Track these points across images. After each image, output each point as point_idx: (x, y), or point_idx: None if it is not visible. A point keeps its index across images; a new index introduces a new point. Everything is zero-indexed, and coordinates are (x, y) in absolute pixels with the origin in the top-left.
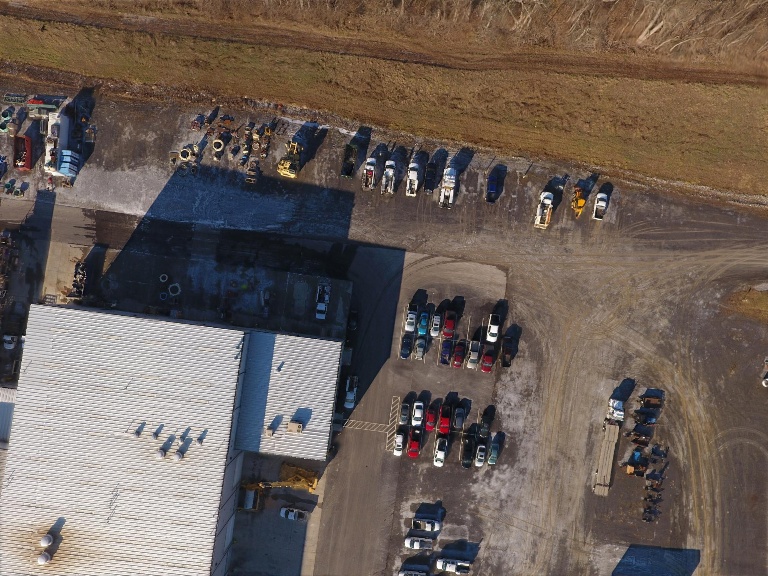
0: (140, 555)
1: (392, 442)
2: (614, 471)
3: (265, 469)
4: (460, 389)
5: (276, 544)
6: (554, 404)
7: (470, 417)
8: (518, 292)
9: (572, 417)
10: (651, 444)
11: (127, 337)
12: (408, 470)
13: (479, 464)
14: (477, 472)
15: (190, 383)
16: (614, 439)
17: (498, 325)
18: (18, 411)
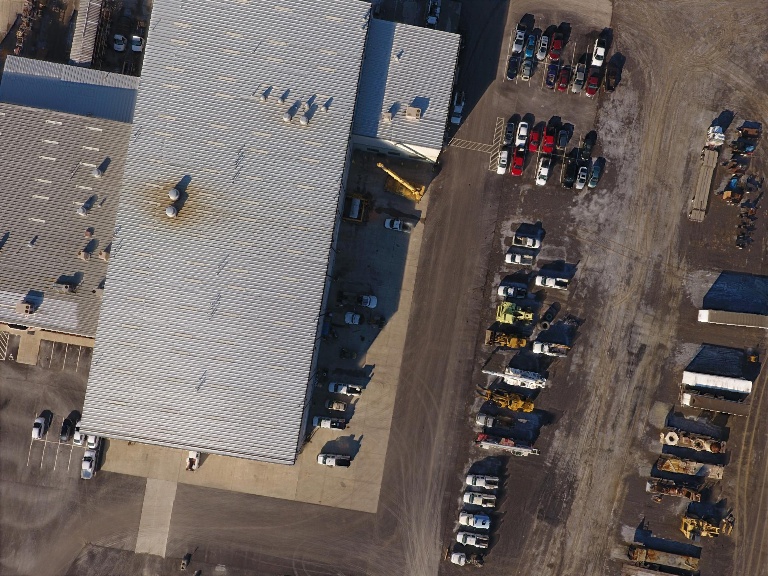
0: (264, 216)
1: (495, 162)
2: (710, 199)
3: (370, 183)
4: (563, 114)
5: (379, 256)
6: (654, 133)
7: (572, 141)
8: (623, 21)
9: (671, 146)
10: (747, 174)
11: (256, 1)
12: (510, 190)
13: (580, 185)
14: (577, 196)
15: (317, 51)
16: (713, 164)
17: (604, 49)
18: (146, 68)
